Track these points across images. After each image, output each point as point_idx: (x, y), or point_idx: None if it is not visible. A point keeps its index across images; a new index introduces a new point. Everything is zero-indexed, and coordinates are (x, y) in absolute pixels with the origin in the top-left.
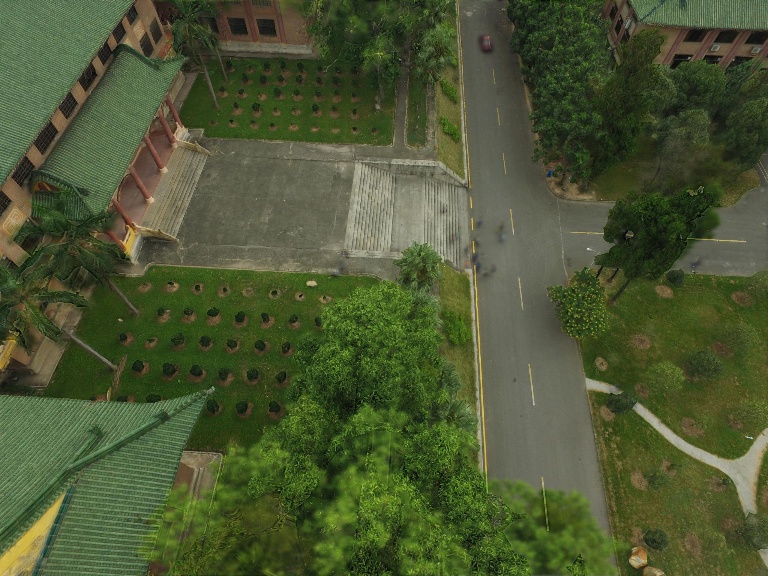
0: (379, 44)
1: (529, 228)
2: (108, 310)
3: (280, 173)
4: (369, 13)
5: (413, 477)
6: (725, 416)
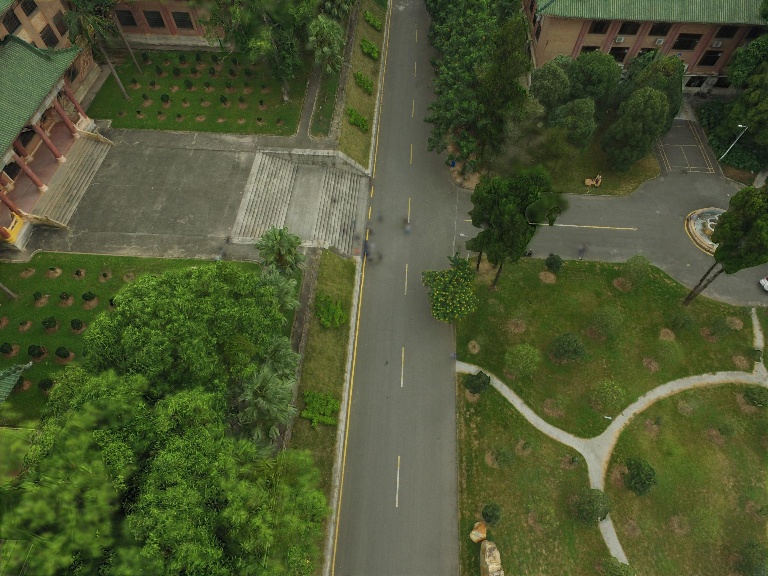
0: (264, 34)
1: (425, 216)
2: None
3: (180, 163)
4: (294, 7)
5: (129, 435)
6: (587, 397)
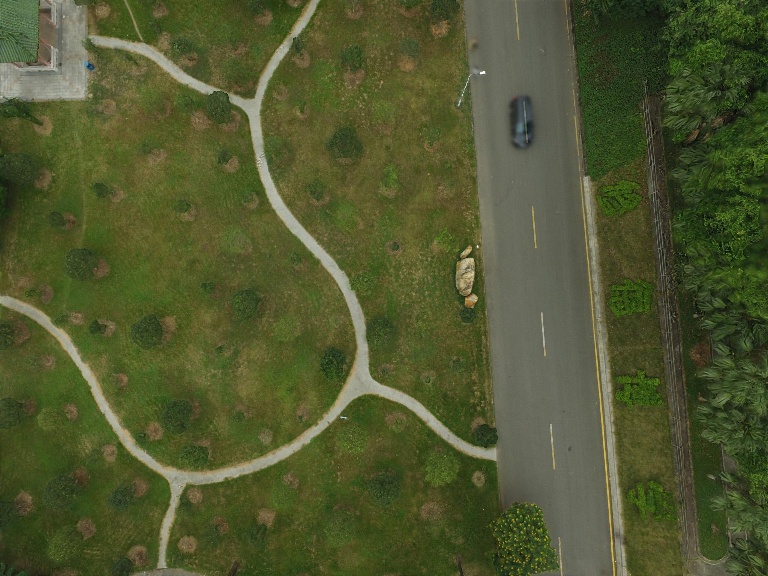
0: None
1: None
2: None
3: None
4: None
5: None
6: None
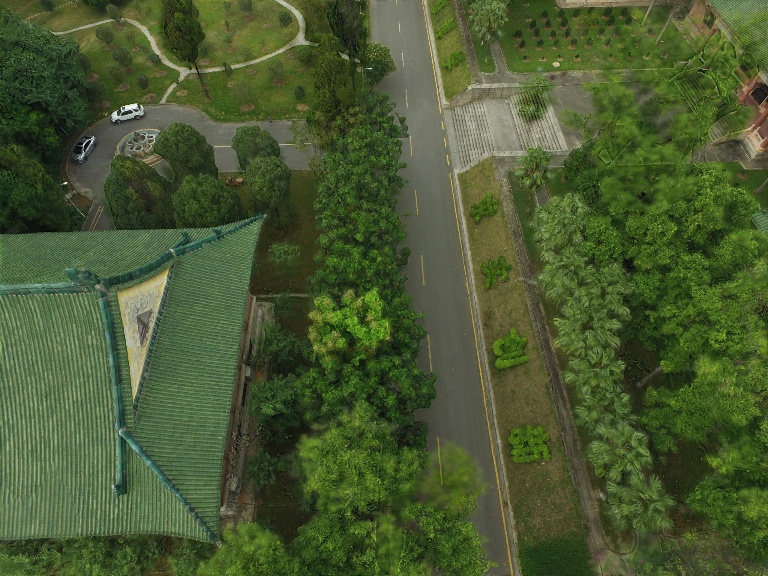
0: None
1: None
2: (675, 45)
3: None
4: None
5: None
6: None
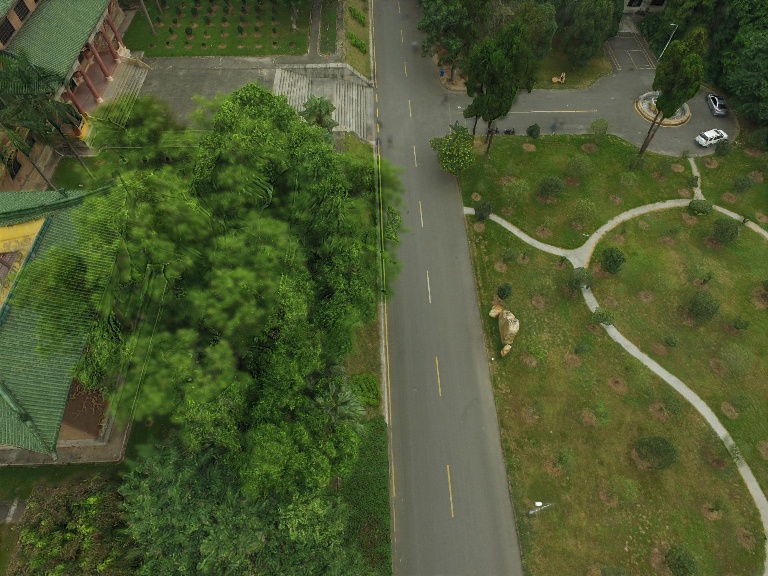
0: None
1: (424, 112)
2: (70, 180)
3: (212, 79)
4: None
5: None
6: (569, 223)
